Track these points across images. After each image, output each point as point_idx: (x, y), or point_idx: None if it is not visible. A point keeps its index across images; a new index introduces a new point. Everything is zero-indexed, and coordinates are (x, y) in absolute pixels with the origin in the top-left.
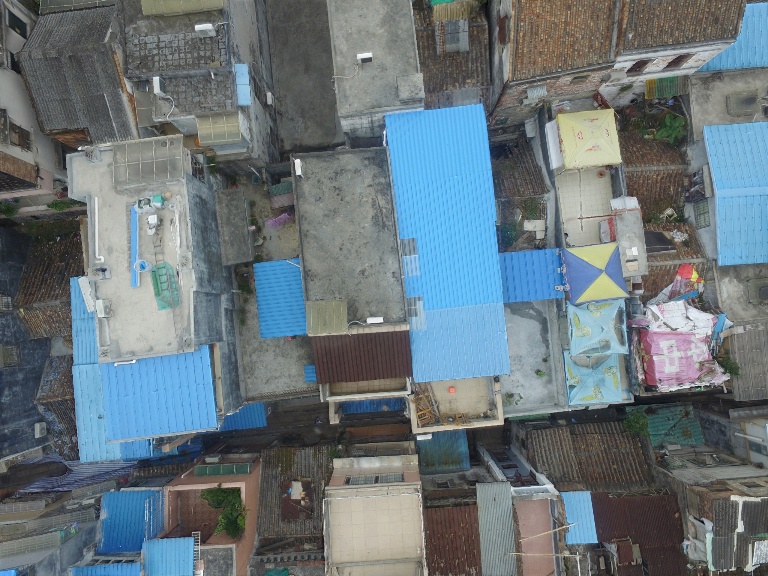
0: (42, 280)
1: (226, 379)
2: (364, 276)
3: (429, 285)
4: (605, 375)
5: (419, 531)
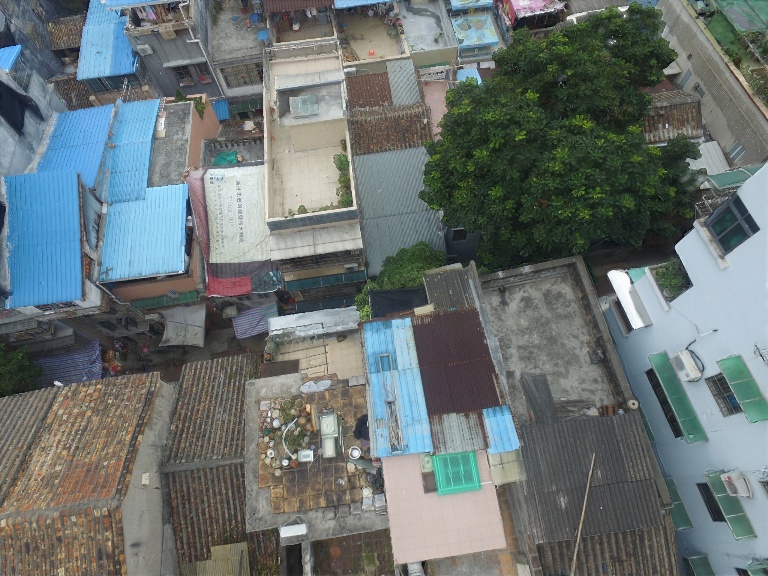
0: (69, 16)
1: (197, 15)
2: None
3: None
4: (484, 30)
5: None
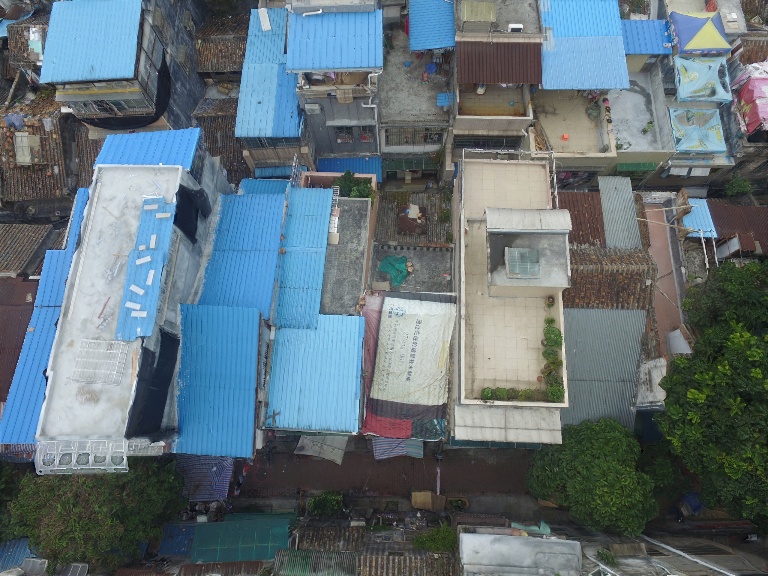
0: (218, 29)
1: None
2: (505, 4)
3: (558, 19)
4: (708, 131)
5: (546, 199)
